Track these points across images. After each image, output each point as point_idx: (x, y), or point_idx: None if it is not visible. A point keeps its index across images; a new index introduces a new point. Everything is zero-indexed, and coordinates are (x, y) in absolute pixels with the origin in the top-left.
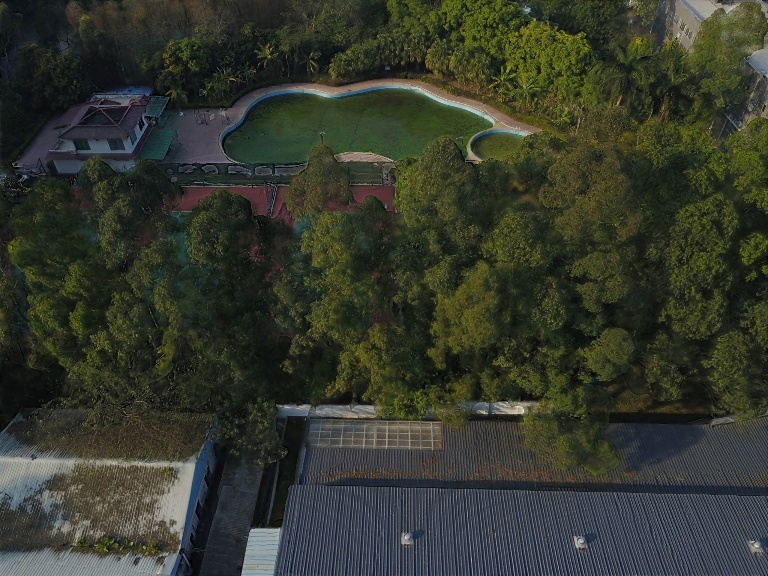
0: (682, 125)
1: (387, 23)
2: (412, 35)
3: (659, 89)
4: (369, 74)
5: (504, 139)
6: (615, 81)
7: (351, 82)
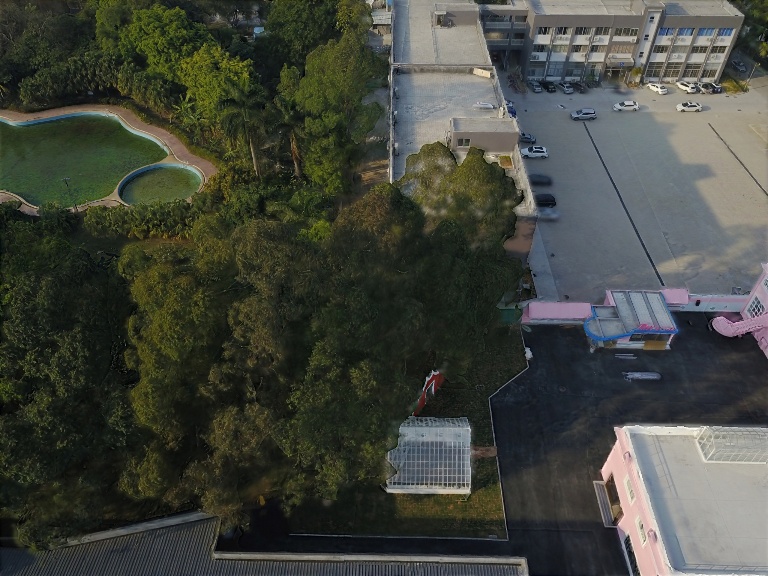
0: (317, 164)
1: (89, 44)
2: (102, 58)
3: (263, 128)
4: (73, 99)
5: (168, 174)
6: (228, 117)
7: (46, 108)
